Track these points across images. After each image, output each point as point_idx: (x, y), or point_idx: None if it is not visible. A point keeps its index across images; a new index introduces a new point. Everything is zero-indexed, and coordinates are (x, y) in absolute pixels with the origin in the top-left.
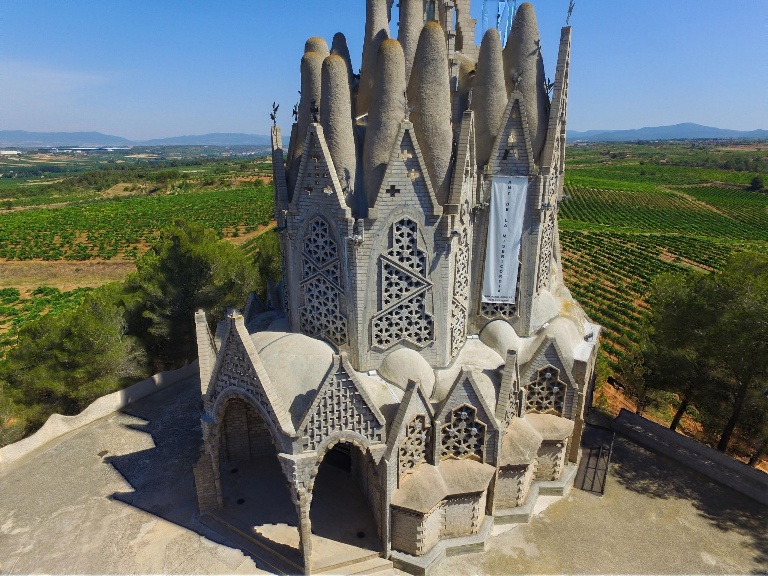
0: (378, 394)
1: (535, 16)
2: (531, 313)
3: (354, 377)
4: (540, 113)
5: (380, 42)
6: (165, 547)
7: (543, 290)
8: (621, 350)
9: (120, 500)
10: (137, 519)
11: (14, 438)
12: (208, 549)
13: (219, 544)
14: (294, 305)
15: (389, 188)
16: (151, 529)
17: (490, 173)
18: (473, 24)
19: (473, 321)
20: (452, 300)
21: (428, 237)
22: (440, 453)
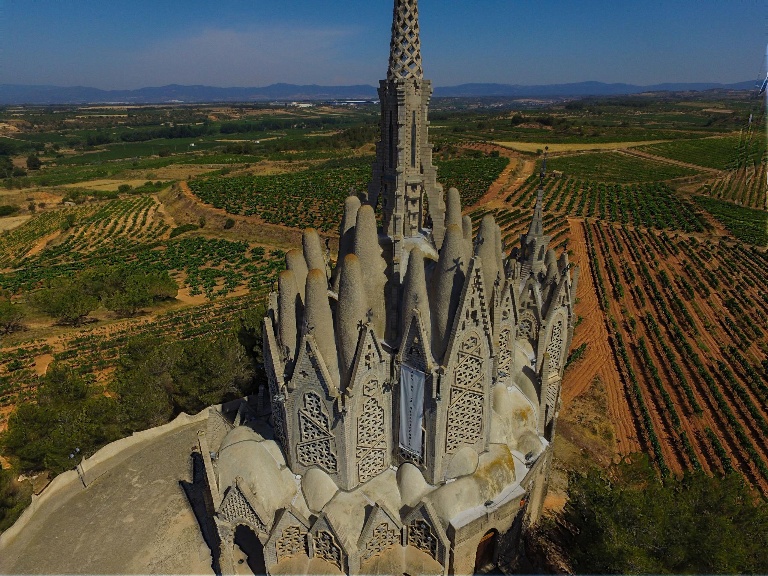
0: (286, 497)
1: (458, 237)
2: (436, 468)
3: (245, 494)
4: (449, 320)
5: (349, 237)
6: (183, 529)
7: (464, 448)
8: (755, 470)
9: (183, 487)
10: (182, 504)
11: (162, 421)
12: (198, 541)
13: (205, 541)
14: (272, 411)
15: (301, 372)
16: (184, 514)
17: (400, 361)
18: (442, 213)
19: (395, 456)
20: (356, 447)
21: (329, 407)
22: (314, 552)
